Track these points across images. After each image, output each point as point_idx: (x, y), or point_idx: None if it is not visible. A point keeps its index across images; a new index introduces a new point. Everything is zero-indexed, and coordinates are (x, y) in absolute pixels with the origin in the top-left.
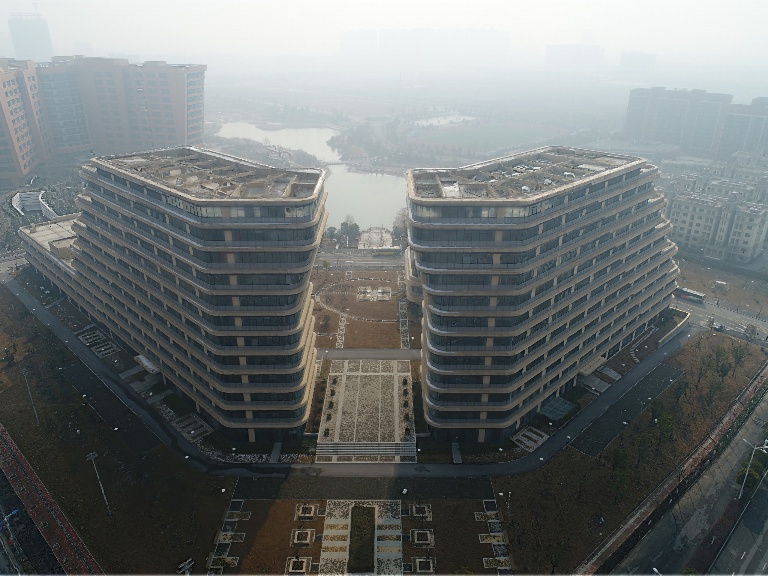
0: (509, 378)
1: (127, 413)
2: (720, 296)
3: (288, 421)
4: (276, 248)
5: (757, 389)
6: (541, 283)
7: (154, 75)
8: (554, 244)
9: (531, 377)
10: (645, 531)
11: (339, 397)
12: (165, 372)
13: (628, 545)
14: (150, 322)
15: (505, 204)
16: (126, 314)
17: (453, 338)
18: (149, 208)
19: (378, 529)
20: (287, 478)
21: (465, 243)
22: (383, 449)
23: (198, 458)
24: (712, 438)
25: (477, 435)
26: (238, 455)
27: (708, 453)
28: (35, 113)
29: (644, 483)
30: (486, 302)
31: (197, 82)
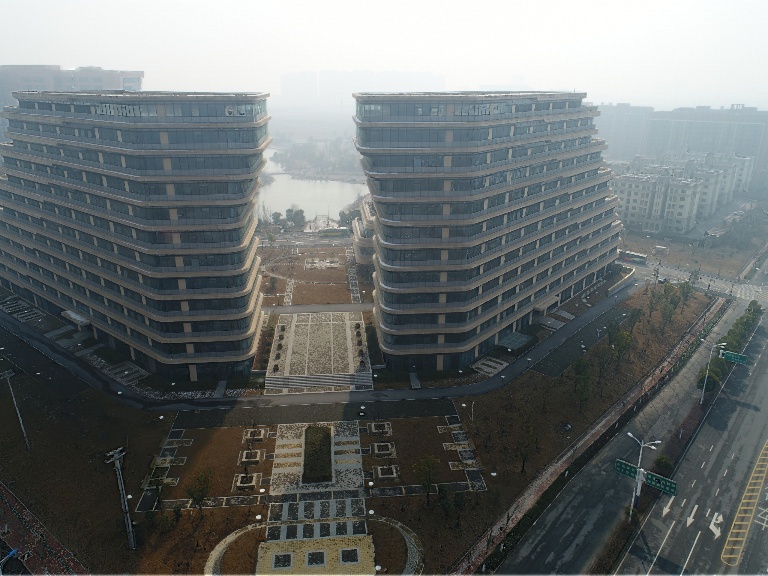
0: (466, 296)
1: (52, 365)
2: (661, 258)
3: (233, 354)
4: (217, 151)
5: (705, 324)
6: (493, 194)
7: (87, 79)
8: (504, 156)
9: (487, 299)
10: (613, 433)
11: (288, 341)
12: (96, 323)
13: (597, 445)
14: (79, 266)
15: (454, 99)
16: (52, 268)
17: (407, 252)
18: (77, 128)
19: (335, 445)
20: (233, 409)
21: (415, 144)
22: (337, 380)
23: (133, 398)
24: (668, 361)
25: (435, 363)
26: (178, 393)
27: (666, 372)
28: None
29: (607, 396)
30: (439, 210)
31: (133, 87)
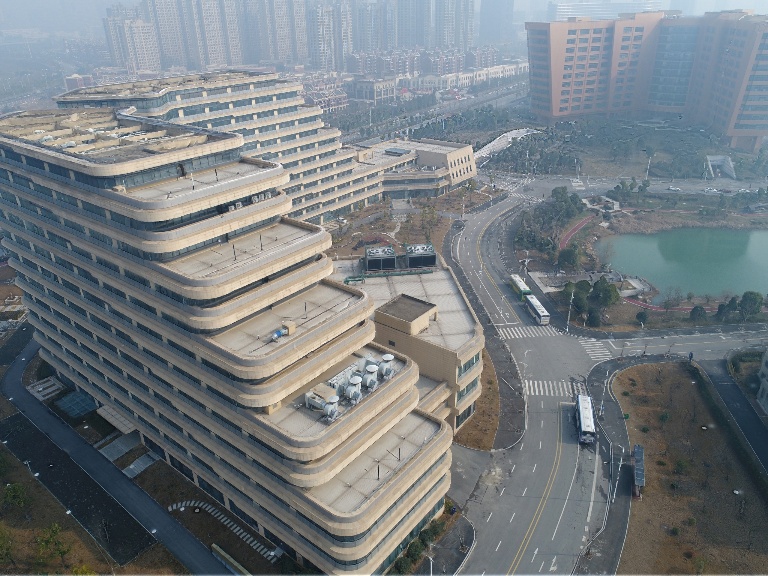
0: None
1: None
2: None
3: None
4: None
5: None
6: None
7: (740, 32)
8: None
9: None
10: None
11: None
12: None
13: None
14: None
15: None
16: None
17: None
18: None
19: None
20: None
21: None
22: None
23: None
24: None
25: None
26: None
27: None
28: (617, 64)
29: None
30: None
31: None
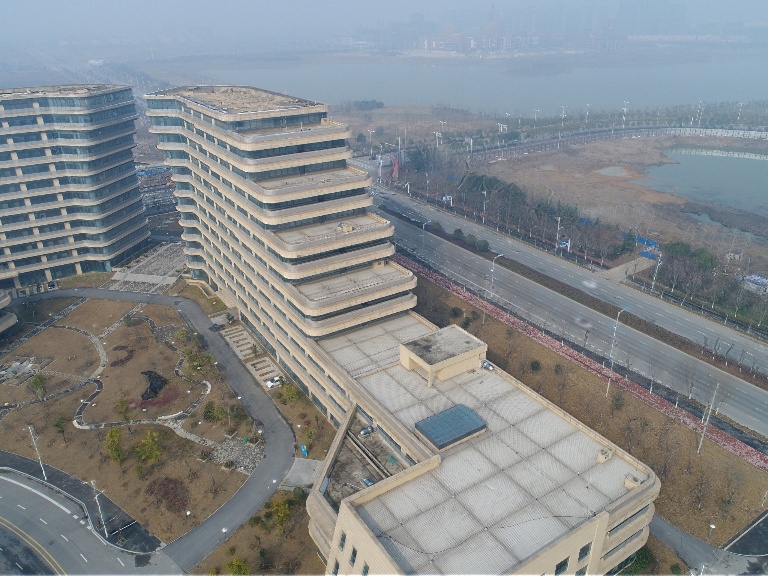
0: None
1: None
2: None
3: None
4: None
5: None
6: None
7: None
8: None
9: None
10: None
11: None
12: None
13: None
14: None
15: None
16: None
17: None
18: None
19: None
20: None
21: None
22: None
23: None
24: None
25: None
26: None
27: None
28: None
29: None
30: None
31: None
